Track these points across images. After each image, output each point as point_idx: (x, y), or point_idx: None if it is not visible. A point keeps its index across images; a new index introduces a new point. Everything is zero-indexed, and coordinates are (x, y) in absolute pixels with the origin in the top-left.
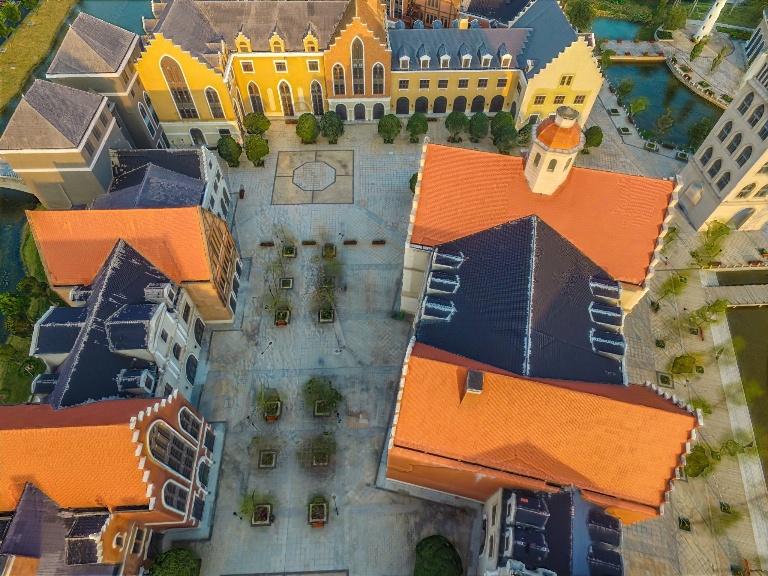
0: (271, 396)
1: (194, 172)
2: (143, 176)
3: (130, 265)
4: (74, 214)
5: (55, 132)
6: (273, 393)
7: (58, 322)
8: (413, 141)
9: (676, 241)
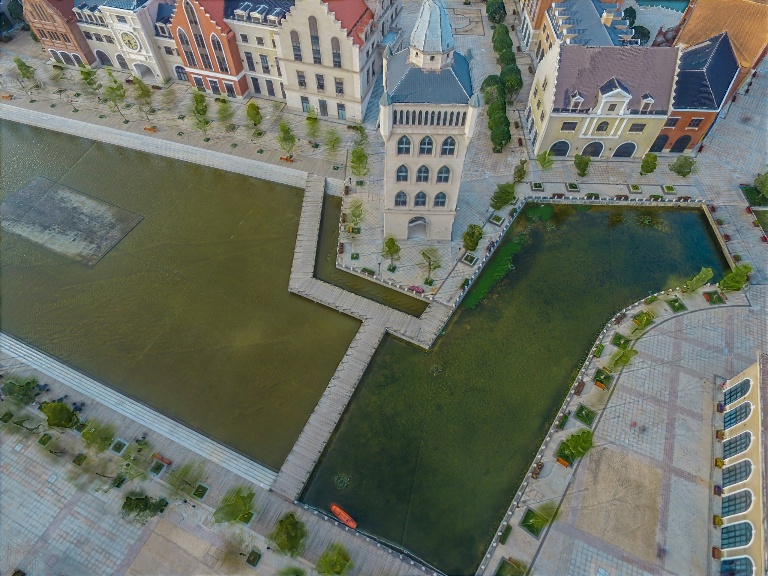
0: None
1: None
2: None
3: None
4: None
5: None
6: None
7: None
8: None
9: (376, 176)
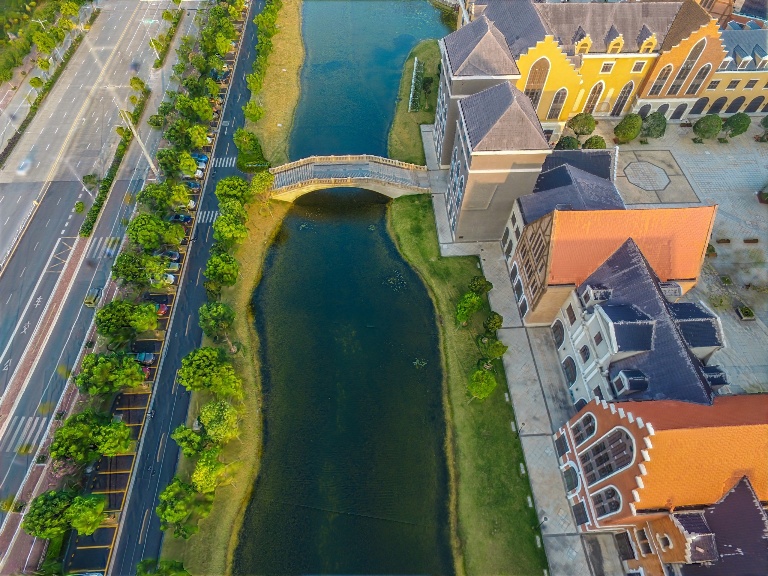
0: (740, 392)
1: (604, 172)
2: (569, 176)
3: (646, 264)
4: (598, 214)
5: (535, 133)
6: (739, 390)
7: (627, 320)
8: (723, 141)
9: None
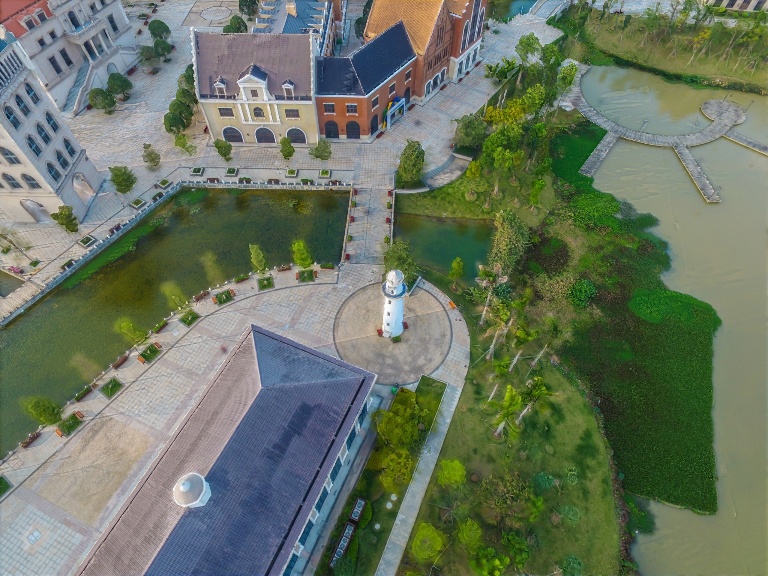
0: None
1: None
2: None
3: None
4: None
5: None
6: None
7: None
8: None
9: None
